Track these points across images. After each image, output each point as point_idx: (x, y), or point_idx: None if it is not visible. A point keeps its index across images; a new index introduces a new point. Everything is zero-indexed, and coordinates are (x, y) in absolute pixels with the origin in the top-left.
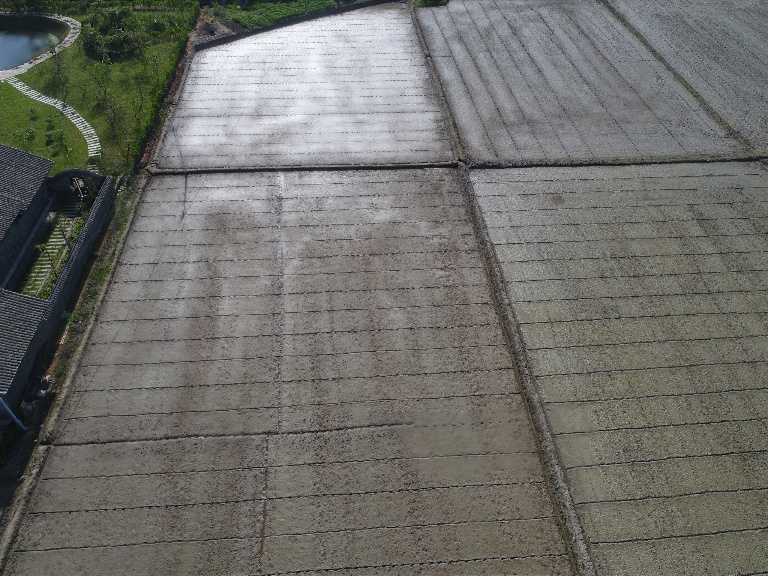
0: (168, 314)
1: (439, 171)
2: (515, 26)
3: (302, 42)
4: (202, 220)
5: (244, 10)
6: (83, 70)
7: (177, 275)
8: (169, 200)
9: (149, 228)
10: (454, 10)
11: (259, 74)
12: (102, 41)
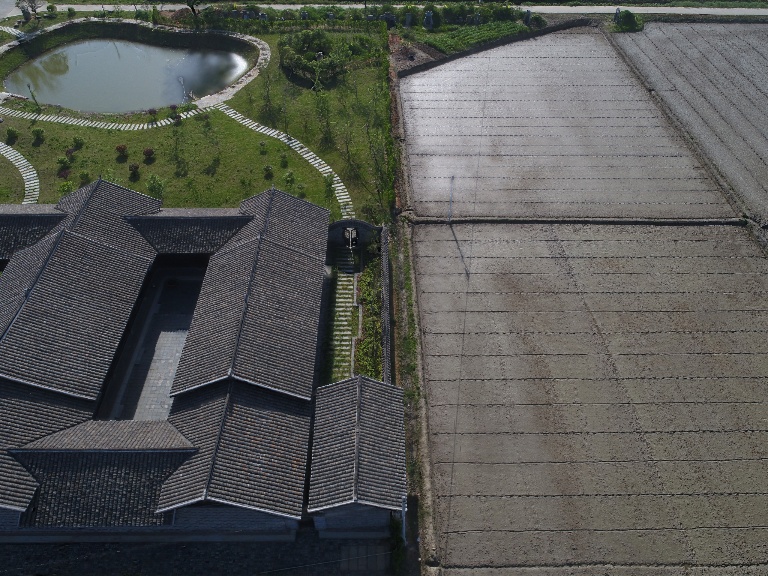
0: (503, 399)
1: (727, 229)
2: (729, 57)
3: (507, 70)
4: (491, 281)
5: (431, 32)
6: (293, 97)
7: (492, 349)
8: (445, 255)
9: (437, 289)
10: (654, 37)
11: (477, 106)
12: (319, 68)
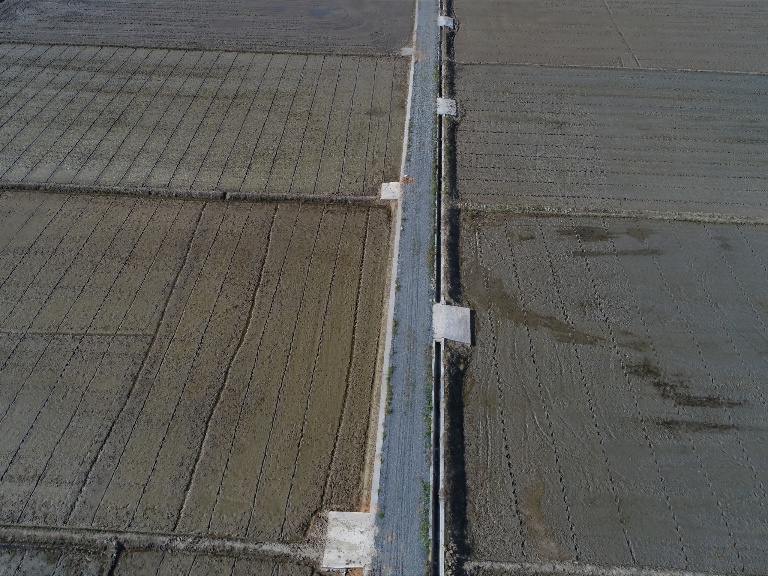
0: None
1: None
2: None
3: None
4: None
5: None
6: None
7: None
8: None
9: None
10: None
11: None
12: None
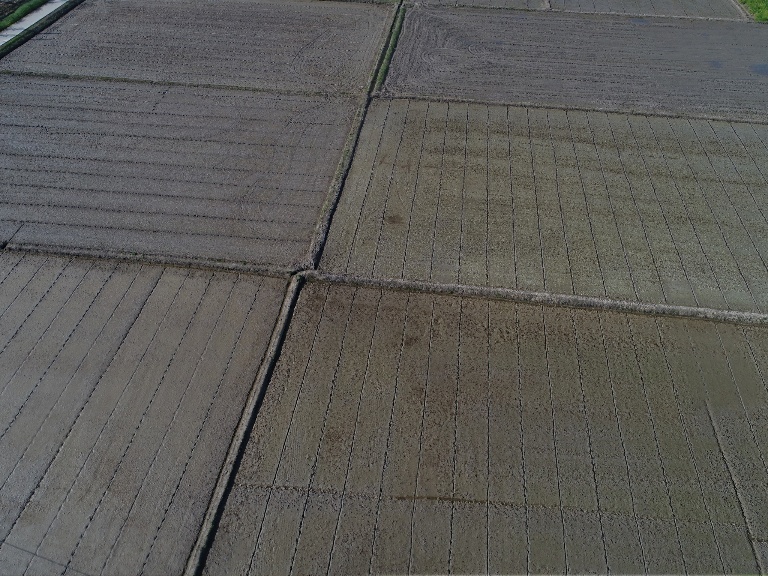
0: None
1: (306, 297)
2: None
3: None
4: None
5: None
6: None
7: None
8: None
9: None
10: None
11: None
12: None
